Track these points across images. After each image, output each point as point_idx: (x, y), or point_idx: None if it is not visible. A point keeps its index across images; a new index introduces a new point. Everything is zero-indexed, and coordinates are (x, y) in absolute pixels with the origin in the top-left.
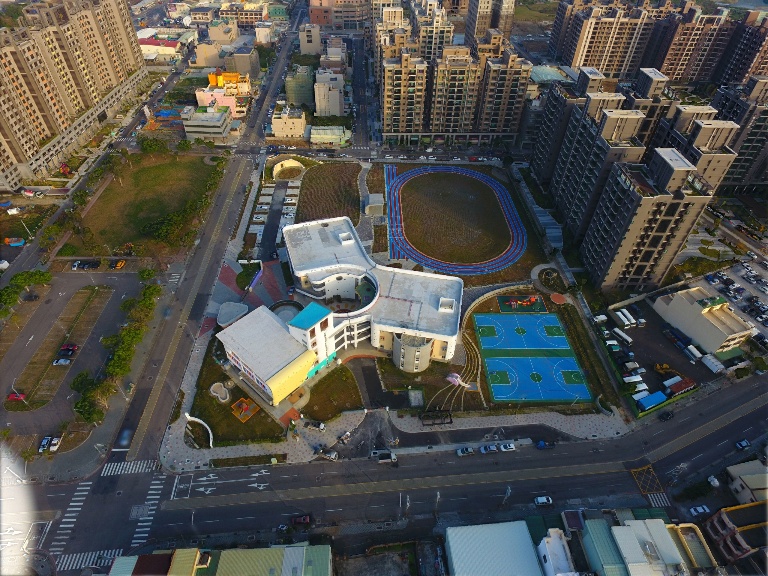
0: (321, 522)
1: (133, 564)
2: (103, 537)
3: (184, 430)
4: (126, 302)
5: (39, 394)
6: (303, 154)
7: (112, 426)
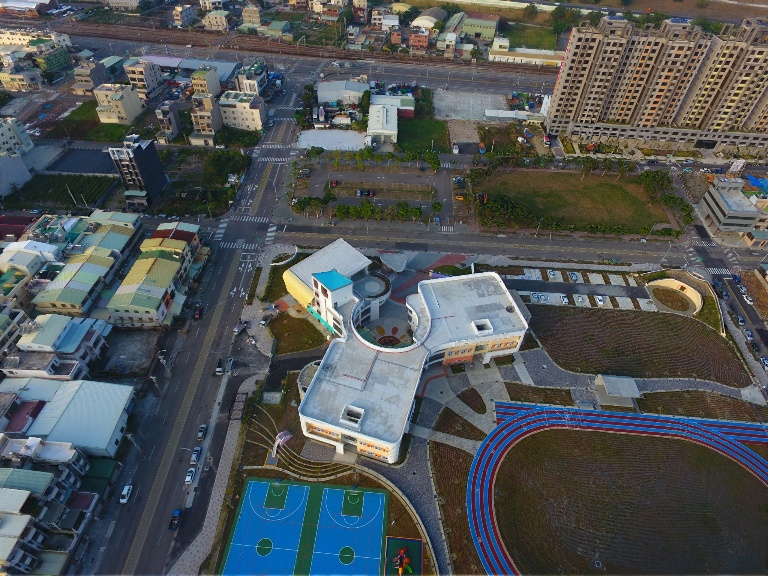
0: (193, 325)
1: (192, 231)
2: (231, 232)
3: (289, 252)
4: (403, 202)
5: (336, 191)
6: (736, 312)
7: (303, 222)
